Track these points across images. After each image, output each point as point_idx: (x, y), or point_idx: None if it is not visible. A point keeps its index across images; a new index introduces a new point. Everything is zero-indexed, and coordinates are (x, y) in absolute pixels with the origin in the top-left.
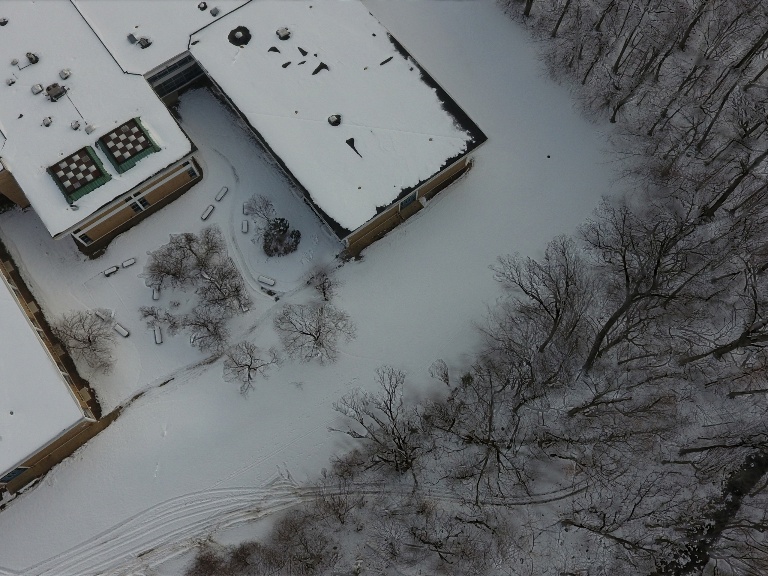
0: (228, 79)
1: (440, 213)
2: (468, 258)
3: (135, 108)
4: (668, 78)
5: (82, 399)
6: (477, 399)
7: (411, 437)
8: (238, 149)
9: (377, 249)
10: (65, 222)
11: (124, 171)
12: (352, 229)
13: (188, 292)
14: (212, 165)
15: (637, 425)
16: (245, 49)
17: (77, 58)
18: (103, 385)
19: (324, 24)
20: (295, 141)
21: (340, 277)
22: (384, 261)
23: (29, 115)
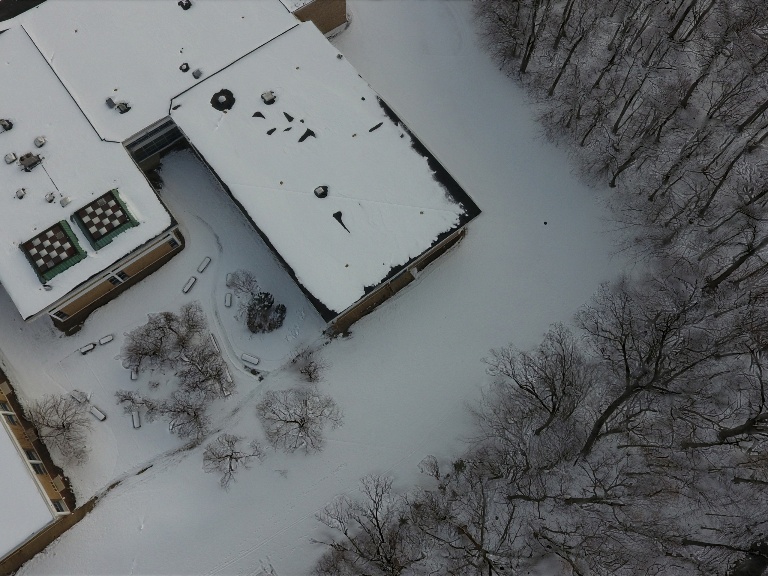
0: (210, 147)
1: (432, 285)
2: (461, 334)
3: (113, 179)
4: (670, 139)
5: (55, 489)
6: (470, 488)
7: (401, 528)
8: (222, 216)
9: (366, 324)
10: (38, 304)
11: (100, 248)
12: (339, 311)
13: (167, 375)
14: (194, 233)
15: (637, 514)
16: (228, 114)
17: (53, 124)
18: (78, 473)
19: (311, 87)
20: (280, 215)
21: (327, 355)
22: (373, 337)
23: (2, 186)
